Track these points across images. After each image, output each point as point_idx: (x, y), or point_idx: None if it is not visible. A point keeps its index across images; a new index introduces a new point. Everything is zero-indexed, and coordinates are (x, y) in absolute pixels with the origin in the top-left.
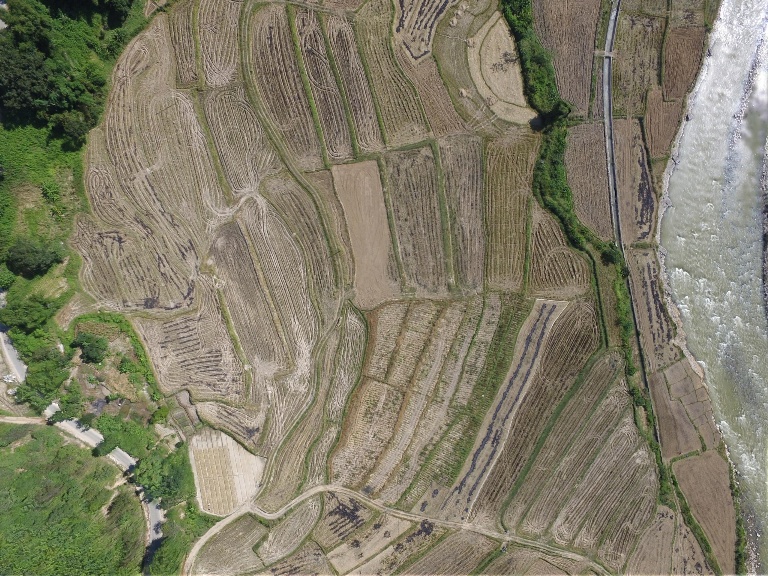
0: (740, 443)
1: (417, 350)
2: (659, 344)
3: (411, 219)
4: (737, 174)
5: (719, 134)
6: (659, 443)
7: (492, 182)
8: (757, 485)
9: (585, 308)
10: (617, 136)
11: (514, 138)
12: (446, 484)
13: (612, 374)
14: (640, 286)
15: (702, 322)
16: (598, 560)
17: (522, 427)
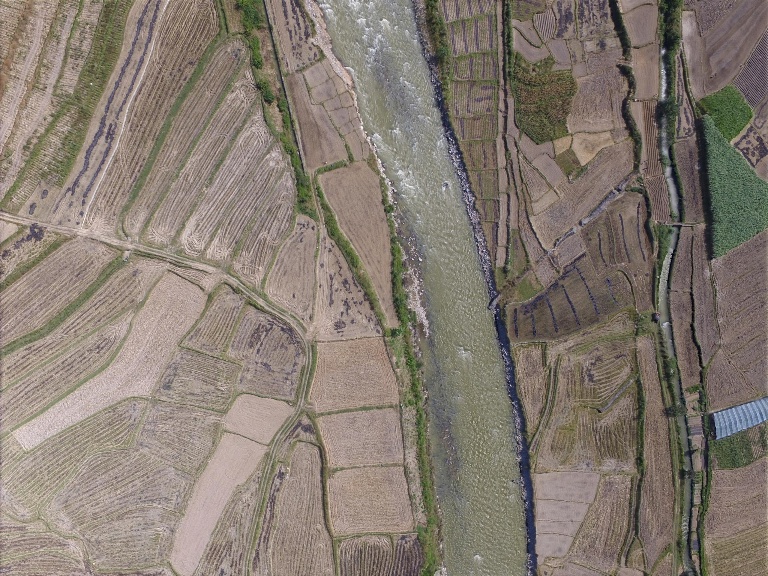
0: (397, 159)
1: (11, 28)
2: (297, 42)
3: None
4: None
5: None
6: (301, 151)
7: None
8: (417, 205)
9: None
10: None
11: None
12: (56, 184)
13: (235, 64)
14: None
15: (347, 24)
16: (233, 273)
17: (139, 121)
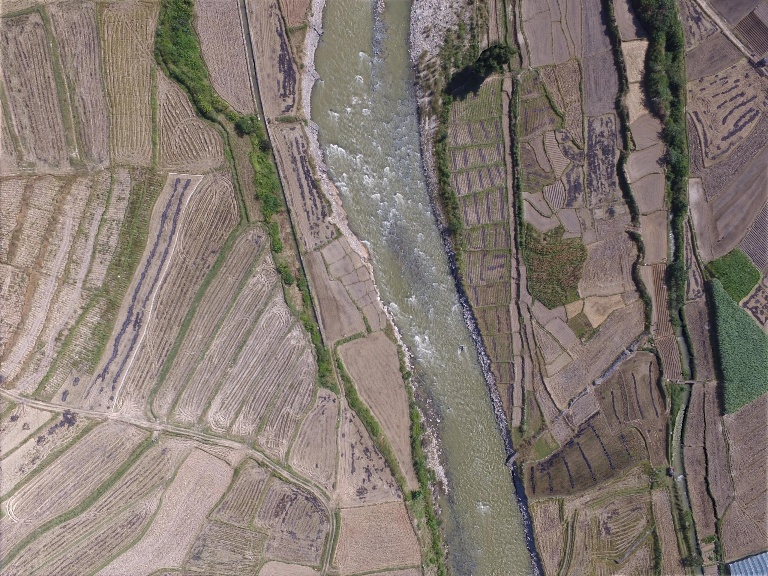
0: (413, 325)
1: (42, 229)
2: (314, 222)
3: (25, 90)
4: (385, 45)
5: (362, 4)
6: (321, 325)
7: (112, 51)
8: (433, 368)
9: (222, 182)
10: (252, 5)
11: (131, 4)
12: (87, 371)
13: (256, 251)
14: (289, 162)
15: (362, 200)
16: (258, 447)
17: (165, 309)
